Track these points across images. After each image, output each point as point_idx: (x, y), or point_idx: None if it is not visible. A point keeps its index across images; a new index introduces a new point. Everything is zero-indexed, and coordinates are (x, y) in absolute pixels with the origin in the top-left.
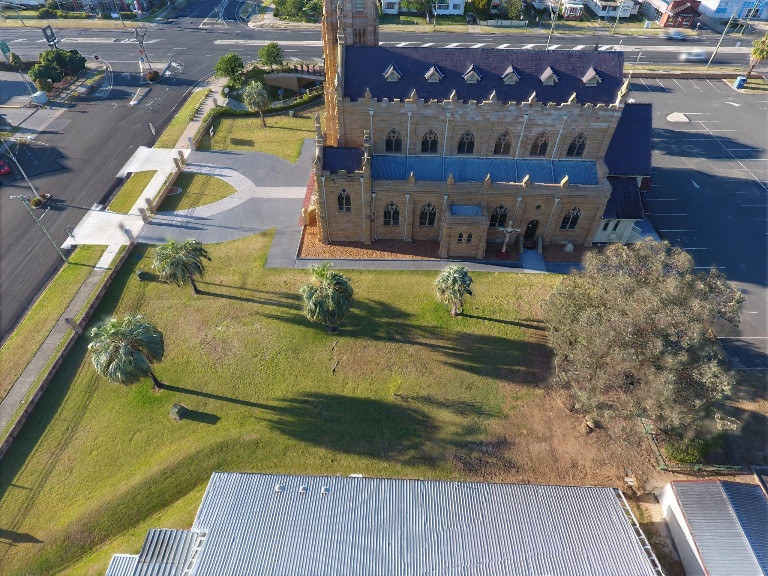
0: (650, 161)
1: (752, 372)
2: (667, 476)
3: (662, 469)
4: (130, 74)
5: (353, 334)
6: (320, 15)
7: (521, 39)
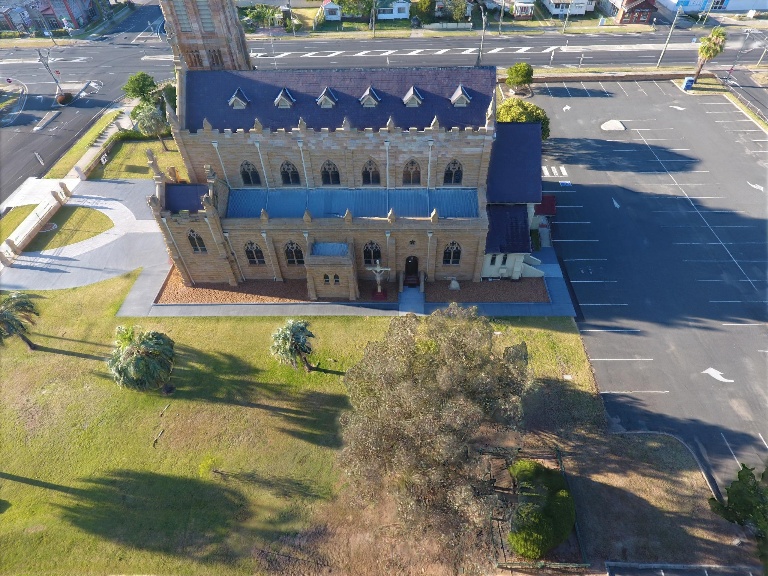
0: (540, 186)
1: (631, 437)
2: (504, 575)
3: (499, 567)
4: (44, 97)
5: (189, 396)
6: (258, 25)
7: (463, 43)
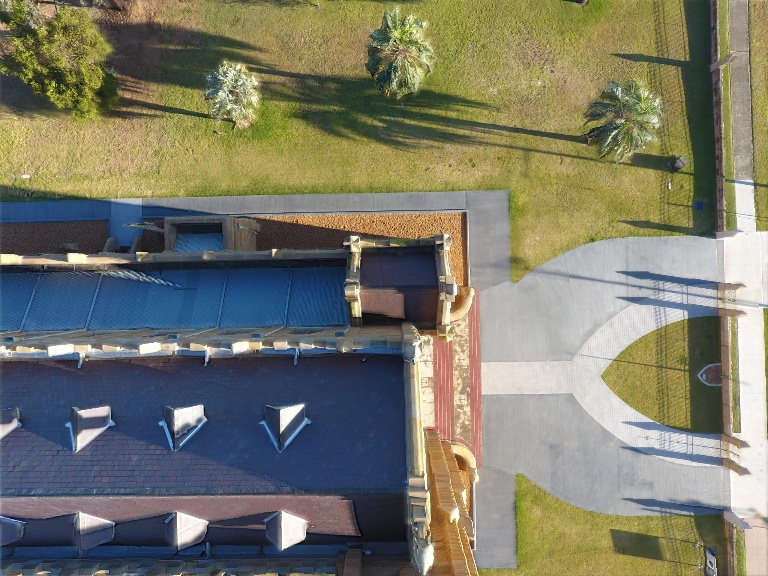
0: None
1: None
2: None
3: None
4: None
5: (371, 84)
6: None
7: None
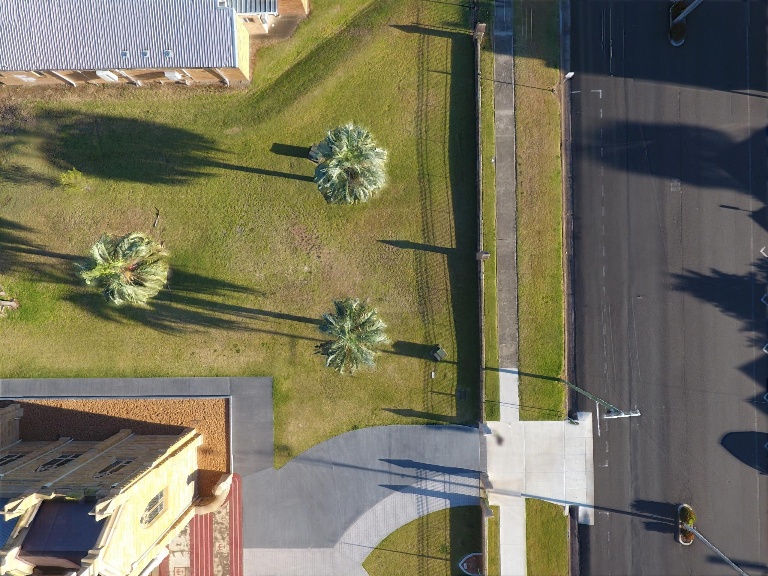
0: None
1: None
2: None
3: None
4: None
5: None
6: None
7: None
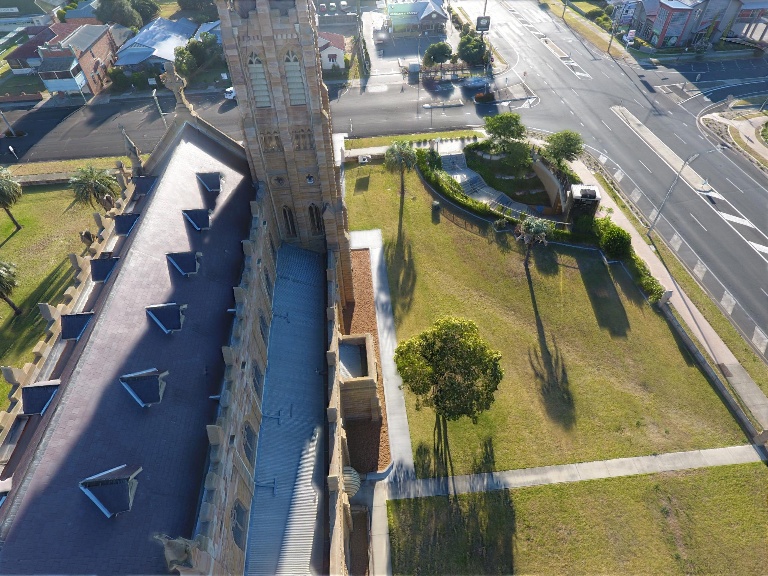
0: None
1: None
2: None
3: None
4: (490, 87)
5: (3, 328)
6: None
7: None
